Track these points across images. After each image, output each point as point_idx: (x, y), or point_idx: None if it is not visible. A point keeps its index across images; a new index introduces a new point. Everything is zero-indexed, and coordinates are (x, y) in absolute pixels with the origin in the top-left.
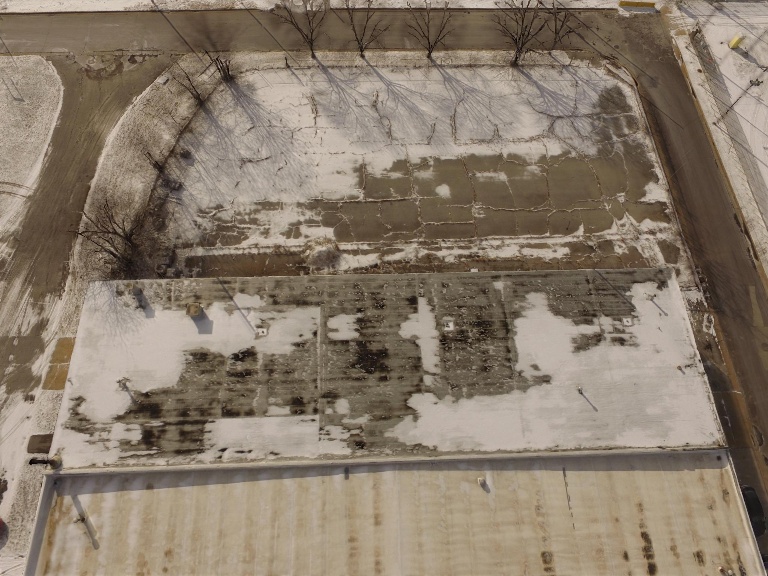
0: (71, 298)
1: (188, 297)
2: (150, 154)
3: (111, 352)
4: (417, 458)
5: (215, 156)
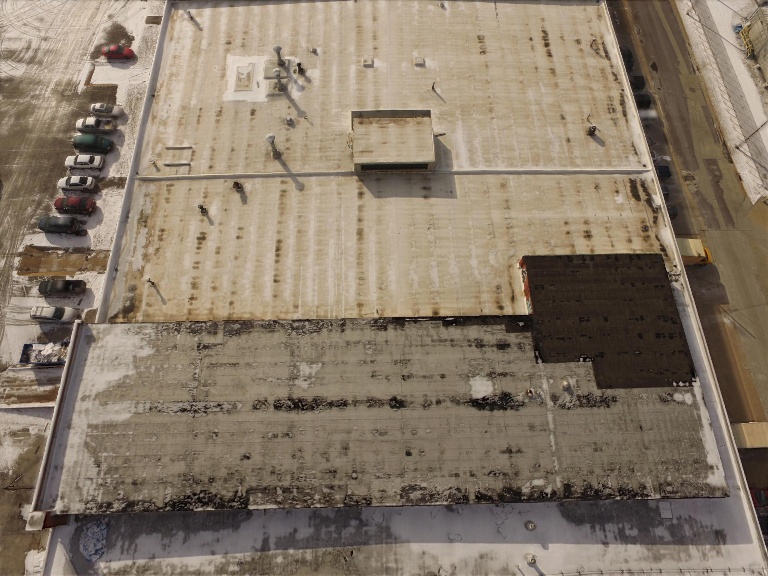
0: None
1: None
2: None
3: None
4: None
5: None
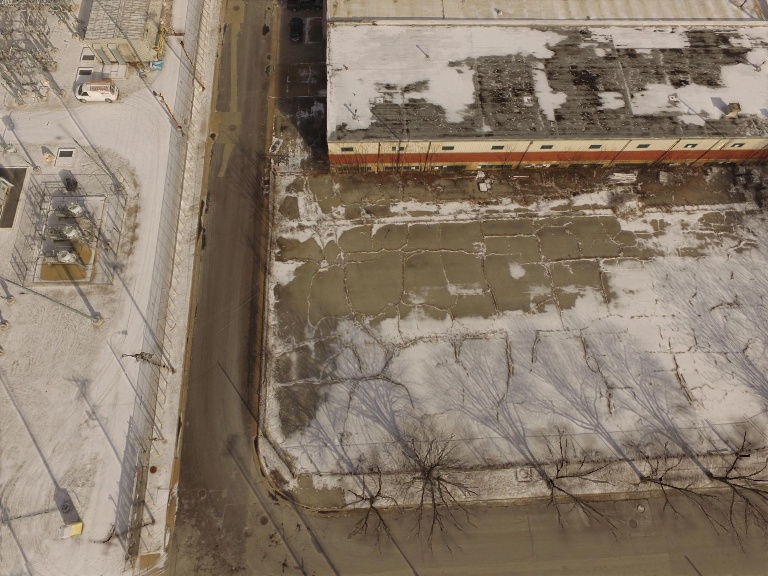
0: None
1: (741, 123)
2: None
3: None
4: (546, 21)
5: None
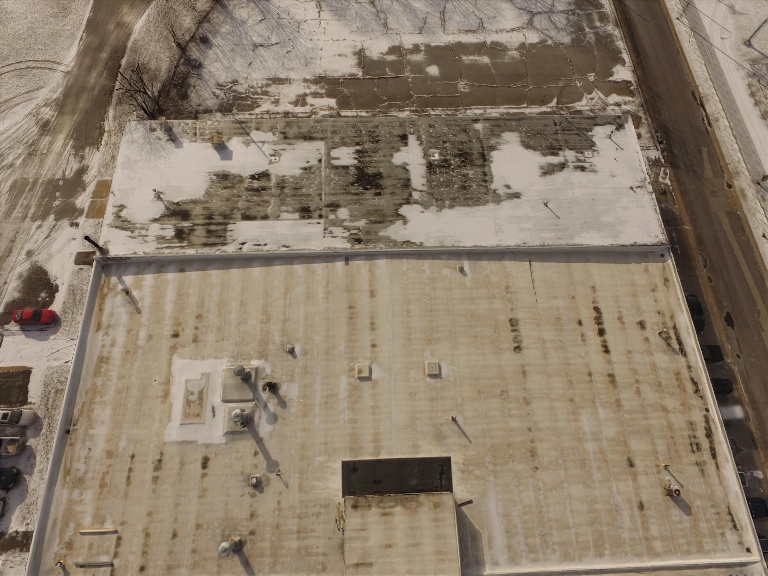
0: (107, 150)
1: (211, 133)
2: (174, 32)
3: (147, 173)
4: (406, 249)
5: (230, 41)
